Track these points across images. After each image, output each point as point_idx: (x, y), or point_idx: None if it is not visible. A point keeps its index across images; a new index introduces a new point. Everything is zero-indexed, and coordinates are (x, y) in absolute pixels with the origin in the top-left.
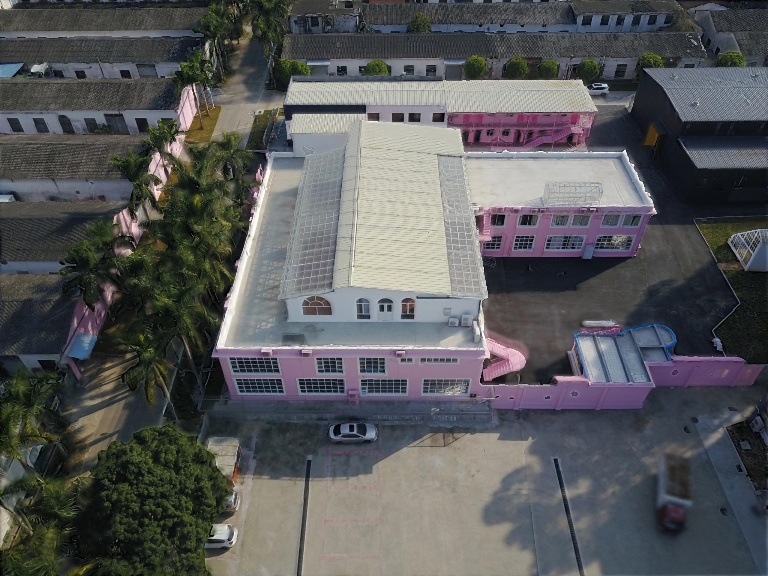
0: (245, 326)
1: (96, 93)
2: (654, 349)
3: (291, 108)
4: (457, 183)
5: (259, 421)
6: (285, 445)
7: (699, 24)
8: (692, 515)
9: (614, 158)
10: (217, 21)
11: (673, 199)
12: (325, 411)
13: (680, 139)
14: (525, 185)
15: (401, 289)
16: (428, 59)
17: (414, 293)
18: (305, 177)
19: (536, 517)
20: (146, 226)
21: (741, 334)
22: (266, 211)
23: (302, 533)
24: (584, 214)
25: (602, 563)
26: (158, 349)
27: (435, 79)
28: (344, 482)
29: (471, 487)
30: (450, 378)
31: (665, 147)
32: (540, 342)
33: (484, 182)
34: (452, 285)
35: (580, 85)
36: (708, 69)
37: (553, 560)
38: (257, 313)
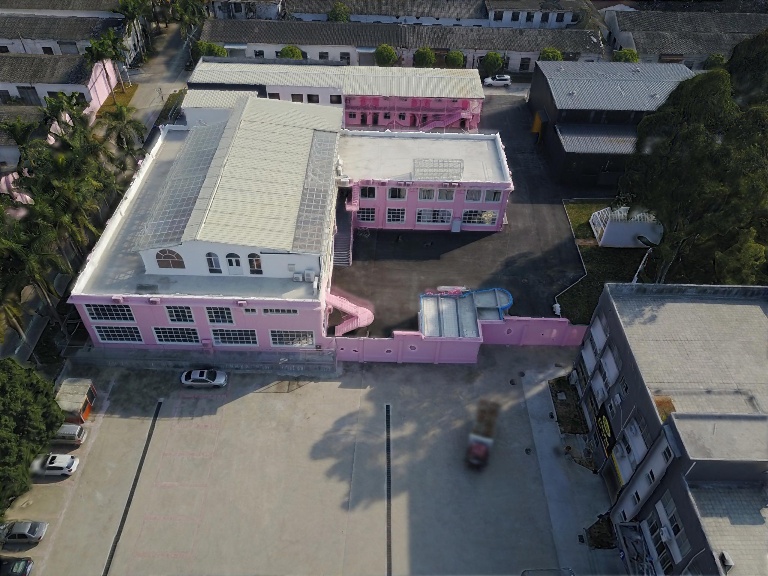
0: (104, 277)
1: (10, 66)
2: (490, 309)
3: (195, 86)
4: (326, 155)
5: (119, 367)
6: (140, 389)
7: (608, 24)
8: (499, 454)
9: (489, 140)
10: (138, 3)
11: (548, 181)
12: (180, 359)
13: (557, 126)
14: (399, 161)
15: (244, 244)
16: (341, 46)
17: (256, 248)
18: (185, 146)
19: (358, 454)
20: (19, 183)
21: (581, 301)
22: (149, 177)
23: (140, 464)
24: (448, 188)
25: (409, 493)
26: (7, 290)
27: (339, 64)
28: (188, 421)
29: (304, 427)
30: (295, 329)
31: (547, 134)
32: (395, 304)
33: (361, 158)
34: (295, 242)
35: (474, 74)
36: (595, 63)
37: (365, 490)
38: (118, 266)
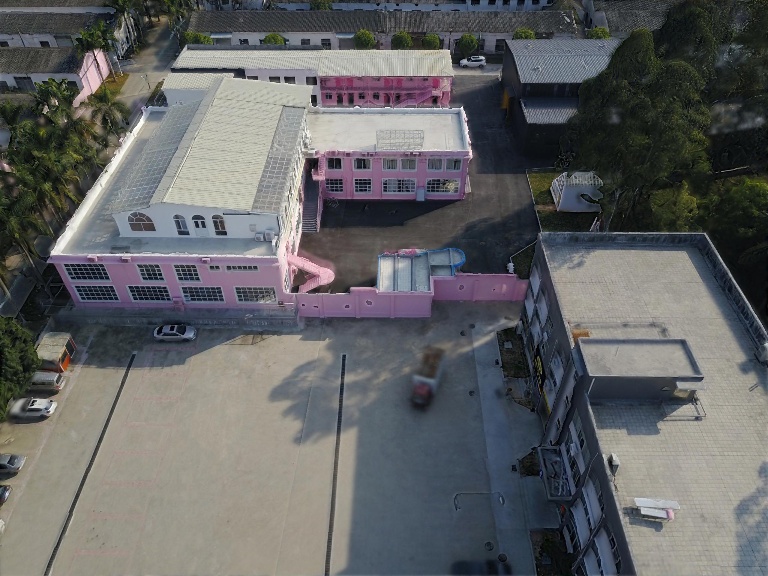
0: (82, 240)
1: (8, 58)
2: (443, 267)
3: (178, 71)
4: (293, 128)
5: (98, 324)
6: (116, 343)
7: (585, 5)
8: (444, 396)
9: (453, 114)
10: None
11: (513, 153)
12: (154, 316)
13: (522, 100)
14: (365, 135)
15: (207, 205)
16: (322, 33)
17: (219, 209)
18: (162, 123)
19: (313, 397)
20: None
21: None
22: (130, 153)
23: (113, 407)
24: (409, 158)
25: (357, 430)
26: None
27: (316, 48)
28: (159, 370)
29: (265, 375)
30: (257, 286)
31: (514, 108)
32: (357, 265)
33: (330, 132)
34: (255, 204)
35: (446, 54)
36: (564, 40)
37: (317, 428)
38: (95, 230)
